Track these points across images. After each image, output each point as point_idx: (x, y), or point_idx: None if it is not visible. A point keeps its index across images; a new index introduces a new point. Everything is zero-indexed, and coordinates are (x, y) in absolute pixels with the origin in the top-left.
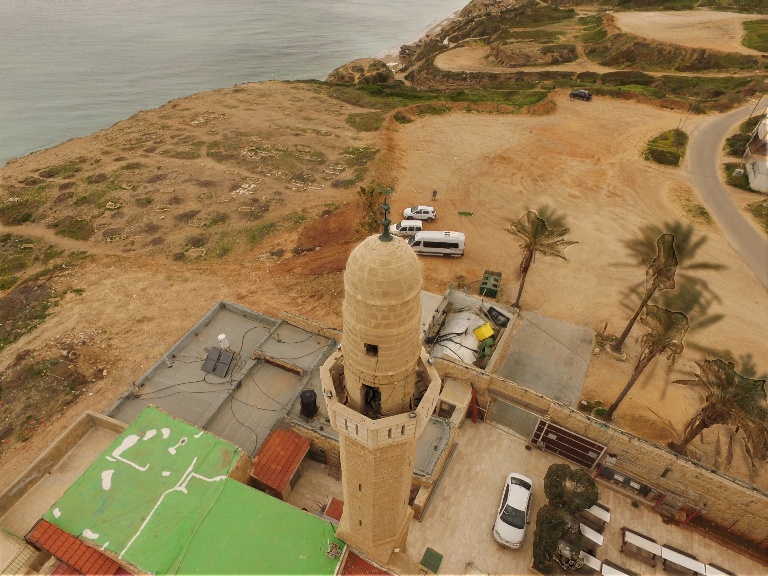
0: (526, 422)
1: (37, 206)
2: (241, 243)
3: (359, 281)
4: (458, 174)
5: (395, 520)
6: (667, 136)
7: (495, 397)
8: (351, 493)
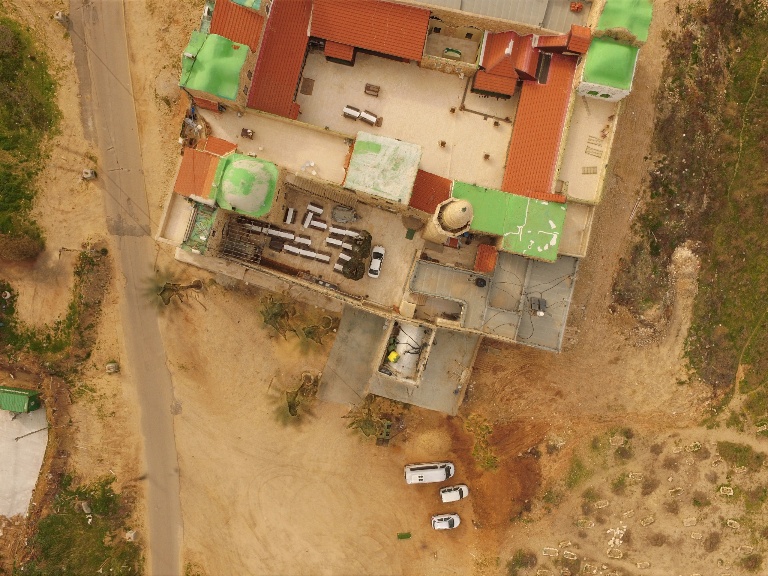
0: None
1: None
2: (586, 458)
3: None
4: None
5: None
6: None
7: (388, 309)
8: None
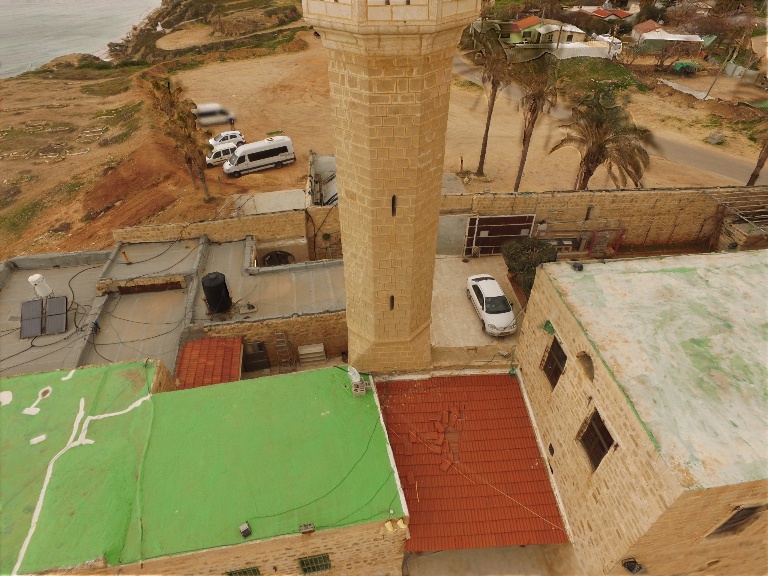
0: (449, 244)
1: None
2: None
3: None
4: (246, 107)
5: (431, 278)
6: None
7: None
8: (378, 236)
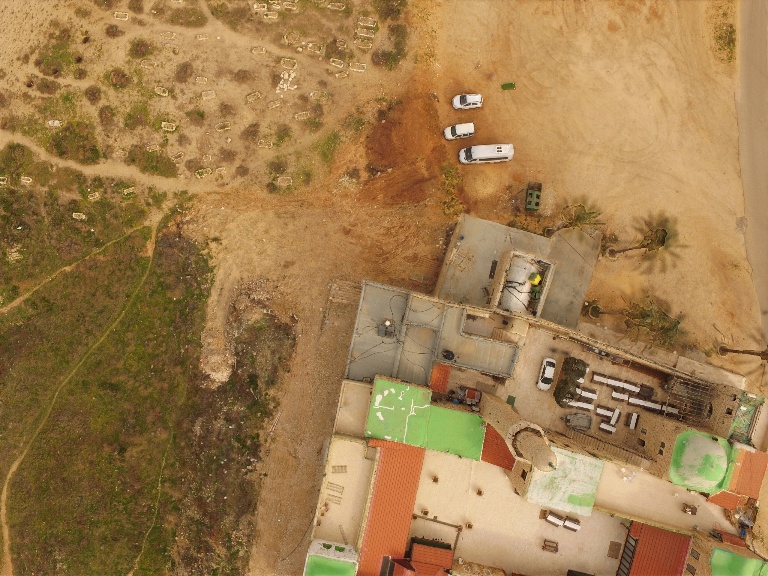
0: None
1: (90, 133)
2: (317, 164)
3: None
4: (497, 5)
5: None
6: None
7: None
8: None
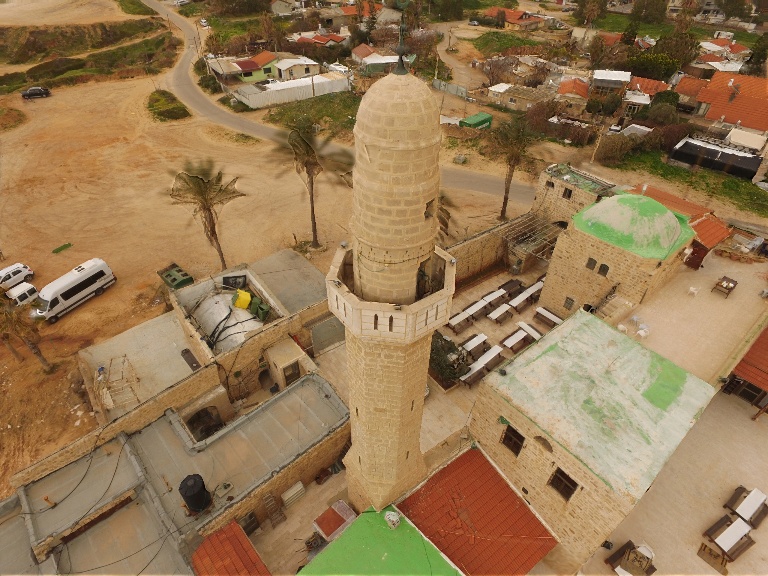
0: (336, 330)
1: None
2: None
3: (419, 124)
4: None
5: None
6: (156, 98)
7: None
8: (402, 426)
